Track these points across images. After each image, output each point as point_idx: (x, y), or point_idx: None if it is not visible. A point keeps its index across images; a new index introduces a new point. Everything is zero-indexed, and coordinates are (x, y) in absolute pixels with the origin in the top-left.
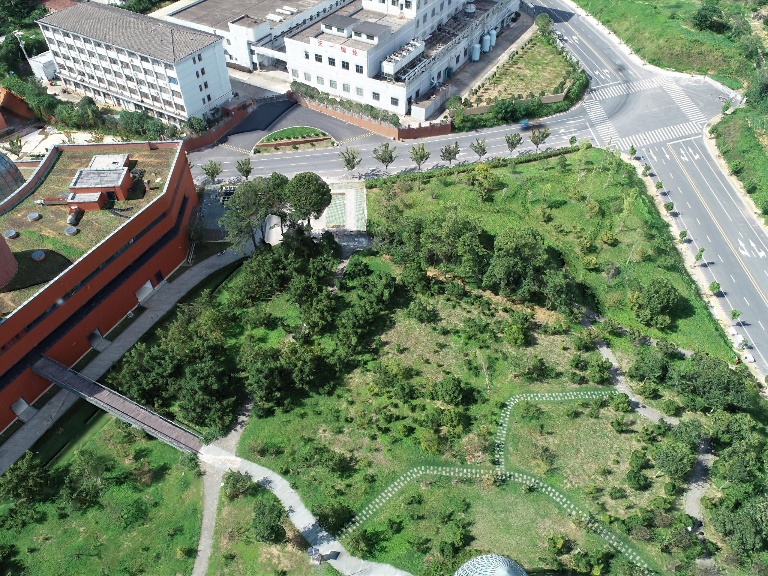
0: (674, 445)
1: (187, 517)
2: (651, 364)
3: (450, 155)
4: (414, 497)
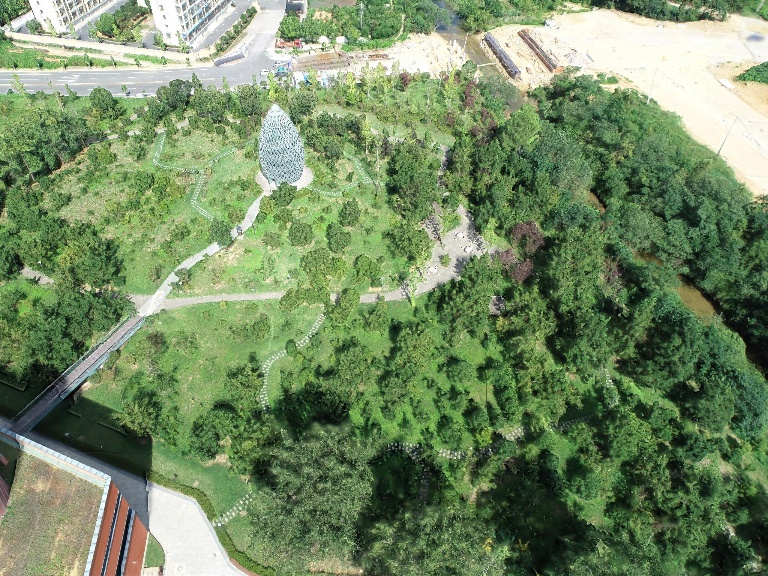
0: None
1: (197, 311)
2: (155, 106)
3: None
4: None
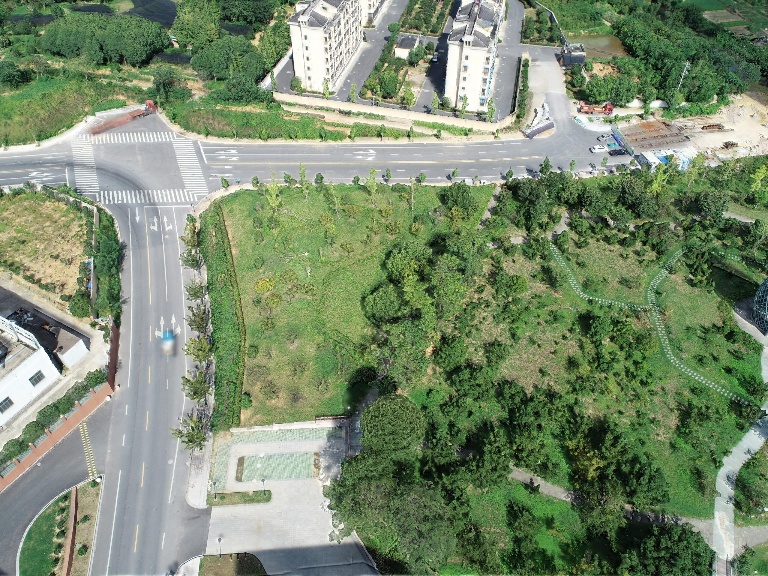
0: (614, 210)
1: None
2: None
3: (203, 321)
4: (701, 359)
